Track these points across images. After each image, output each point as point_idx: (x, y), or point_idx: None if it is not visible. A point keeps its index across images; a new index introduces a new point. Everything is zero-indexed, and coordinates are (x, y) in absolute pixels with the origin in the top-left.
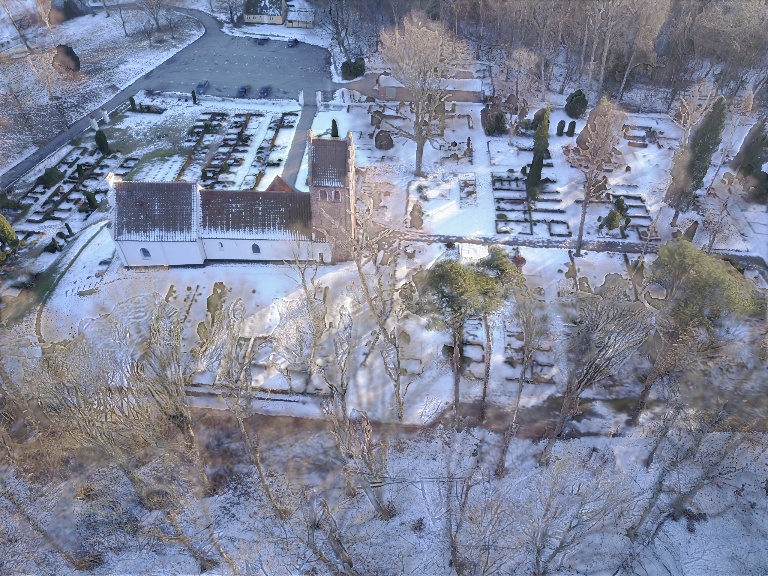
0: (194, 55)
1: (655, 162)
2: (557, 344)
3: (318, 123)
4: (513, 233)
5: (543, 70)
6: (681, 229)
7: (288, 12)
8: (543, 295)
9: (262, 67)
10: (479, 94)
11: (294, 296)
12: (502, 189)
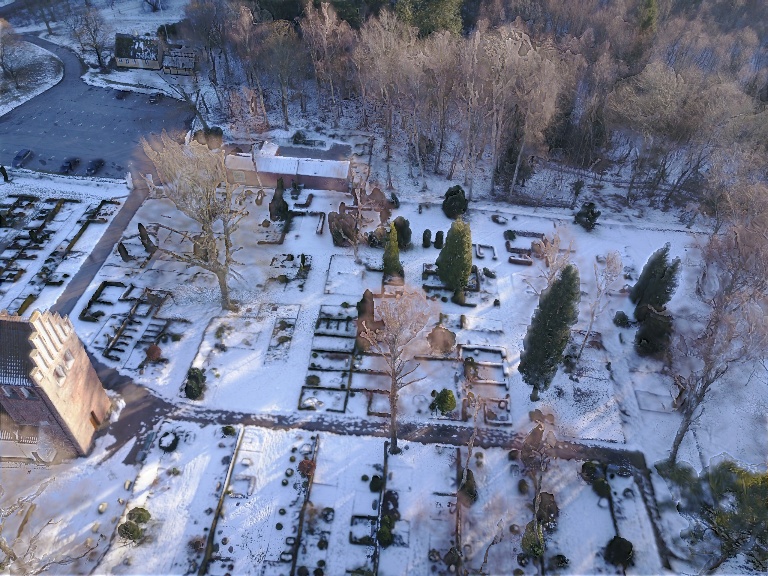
0: (35, 111)
1: None
2: None
3: (140, 216)
4: (320, 409)
5: (425, 152)
6: (543, 404)
7: (164, 57)
8: (330, 522)
9: (107, 131)
10: (345, 181)
11: None
12: (325, 335)
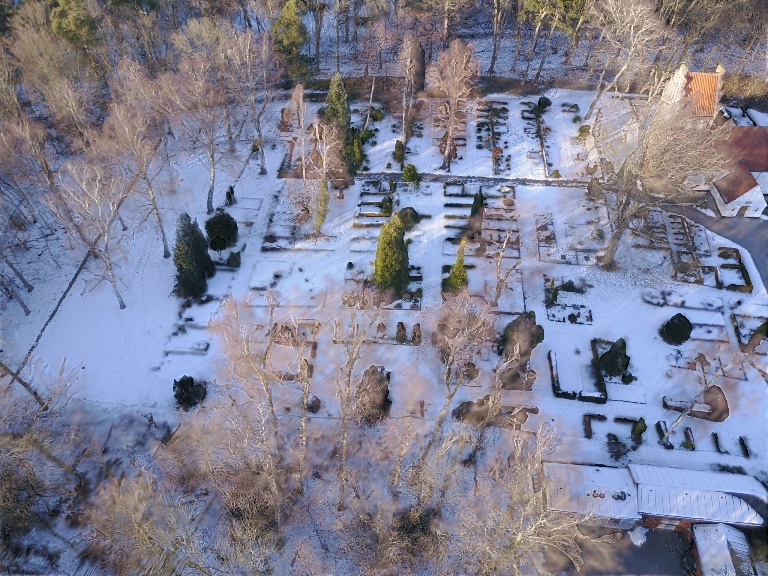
0: None
1: (304, 288)
2: (472, 120)
3: None
4: (498, 187)
5: None
6: None
7: None
8: None
9: None
10: None
11: None
12: None
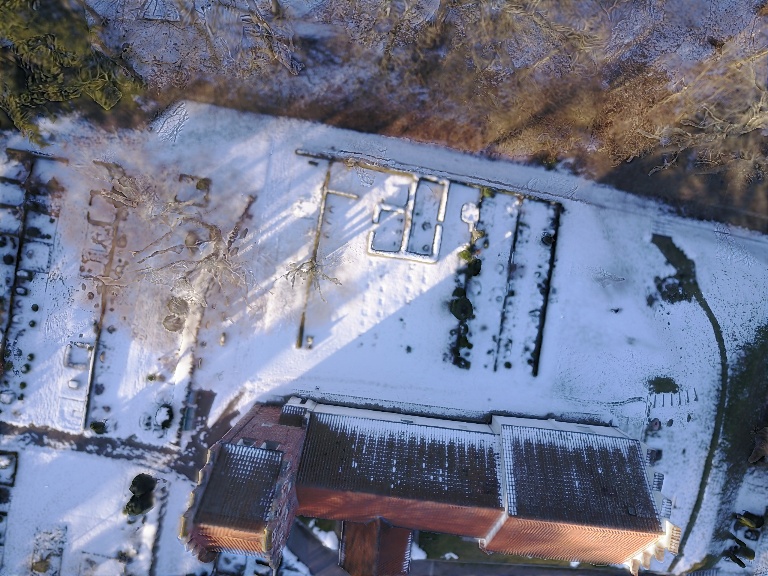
0: None
1: None
2: None
3: None
4: None
5: None
6: None
7: None
8: None
9: None
10: None
11: (348, 335)
12: None
